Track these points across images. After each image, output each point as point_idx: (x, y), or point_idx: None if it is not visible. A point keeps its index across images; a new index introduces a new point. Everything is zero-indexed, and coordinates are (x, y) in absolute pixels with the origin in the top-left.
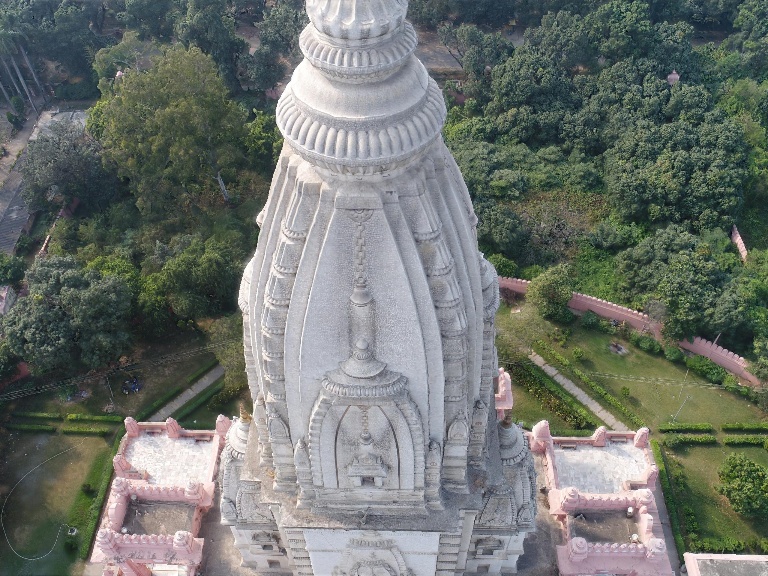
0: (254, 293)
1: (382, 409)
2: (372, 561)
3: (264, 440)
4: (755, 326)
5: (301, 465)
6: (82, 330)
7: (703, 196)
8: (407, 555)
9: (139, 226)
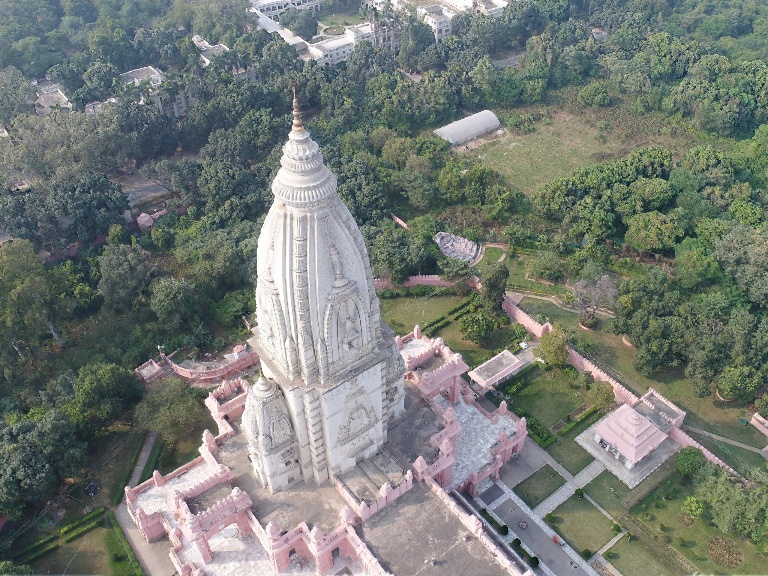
0: (284, 277)
1: (352, 299)
2: (357, 407)
3: (293, 362)
4: (434, 255)
5: (323, 353)
6: (53, 455)
7: (368, 204)
8: (369, 396)
9: (9, 393)
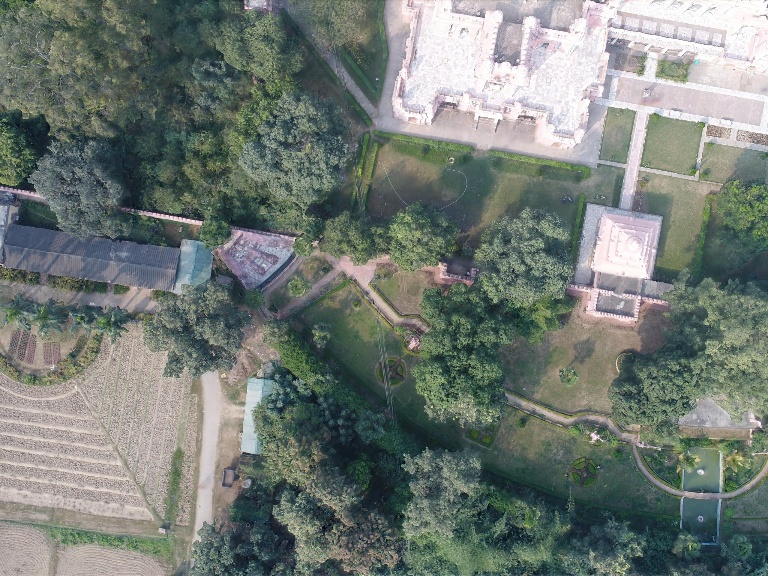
0: None
1: None
2: None
3: None
4: None
5: None
6: None
7: None
8: None
9: (162, 129)
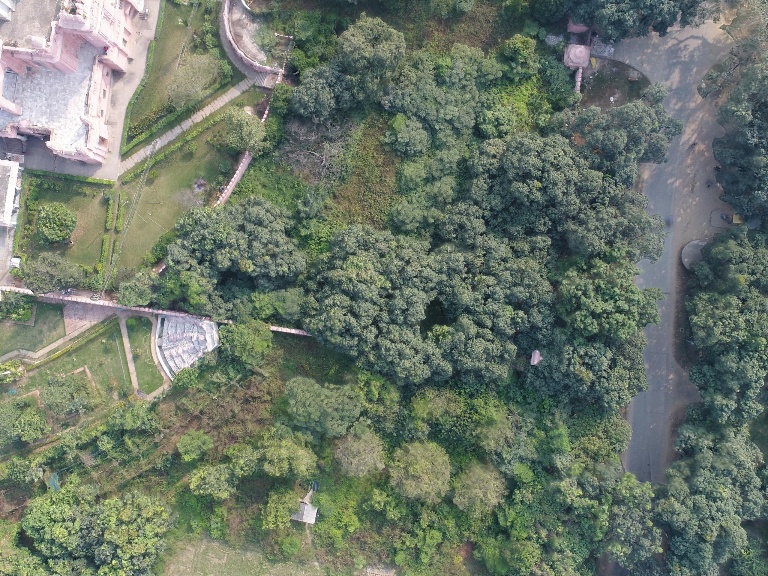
0: None
1: None
2: None
3: None
4: None
5: None
6: None
7: None
8: None
9: None
